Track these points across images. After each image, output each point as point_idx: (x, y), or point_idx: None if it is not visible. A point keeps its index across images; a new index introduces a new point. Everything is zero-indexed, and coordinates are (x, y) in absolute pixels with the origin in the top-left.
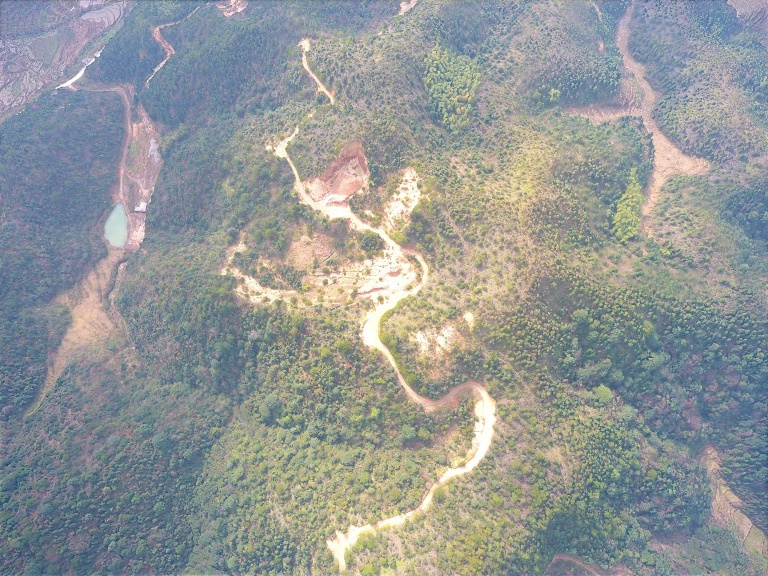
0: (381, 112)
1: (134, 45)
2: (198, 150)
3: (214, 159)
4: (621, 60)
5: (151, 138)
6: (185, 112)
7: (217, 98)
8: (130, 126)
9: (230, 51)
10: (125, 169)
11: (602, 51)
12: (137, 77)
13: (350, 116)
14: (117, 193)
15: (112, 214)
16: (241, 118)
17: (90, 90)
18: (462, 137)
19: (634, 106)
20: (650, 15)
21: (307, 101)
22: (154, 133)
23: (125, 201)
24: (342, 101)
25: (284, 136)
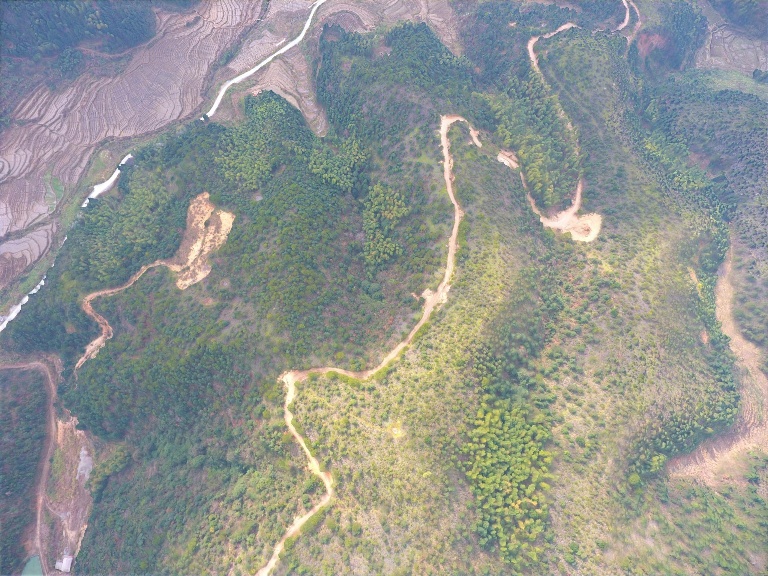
0: (407, 573)
1: (57, 319)
2: (135, 535)
3: (155, 574)
4: (732, 357)
5: (81, 447)
6: (125, 427)
7: (167, 421)
8: (54, 424)
9: (182, 373)
10: (44, 497)
11: (706, 346)
12: (63, 355)
13: (357, 556)
14: (32, 538)
15: (24, 573)
16: (199, 470)
17: (2, 366)
18: (529, 571)
19: (753, 425)
20: (761, 272)
21: (292, 480)
22: (86, 439)
23: (43, 551)
24: (344, 500)
25: (257, 567)
